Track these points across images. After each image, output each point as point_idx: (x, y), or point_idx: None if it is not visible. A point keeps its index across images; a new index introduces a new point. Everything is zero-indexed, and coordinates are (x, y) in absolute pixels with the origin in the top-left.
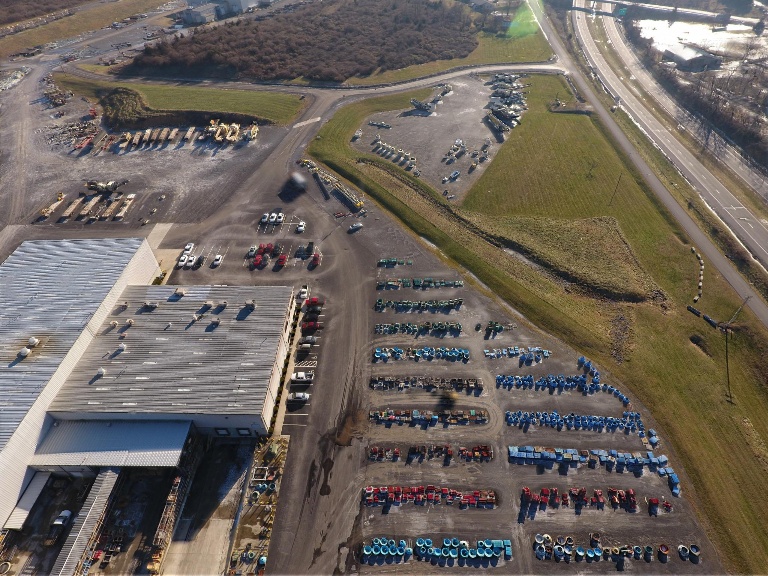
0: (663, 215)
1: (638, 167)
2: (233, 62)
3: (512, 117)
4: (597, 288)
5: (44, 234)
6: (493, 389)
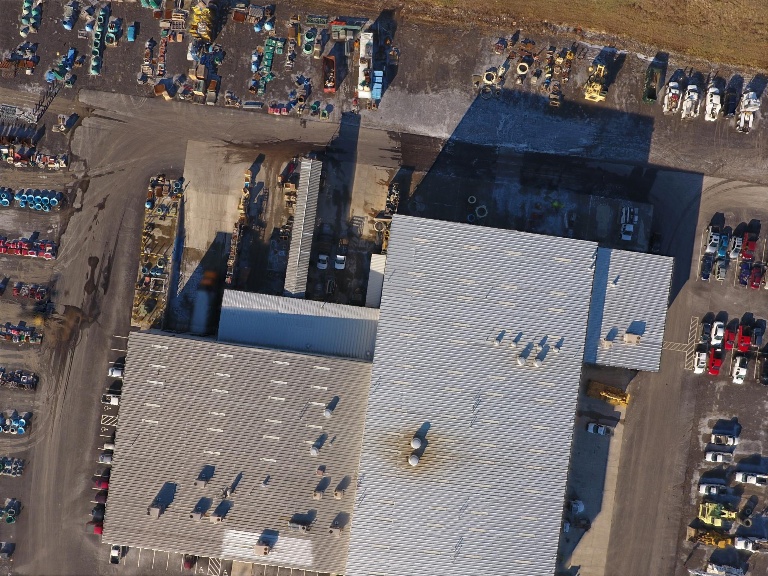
0: None
1: None
2: None
3: None
4: None
5: None
6: None
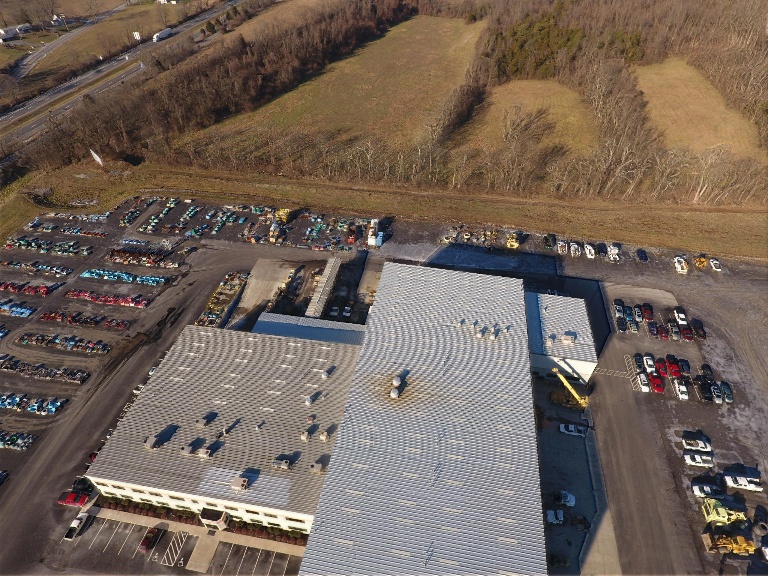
0: None
1: None
2: None
3: None
4: None
5: None
6: None
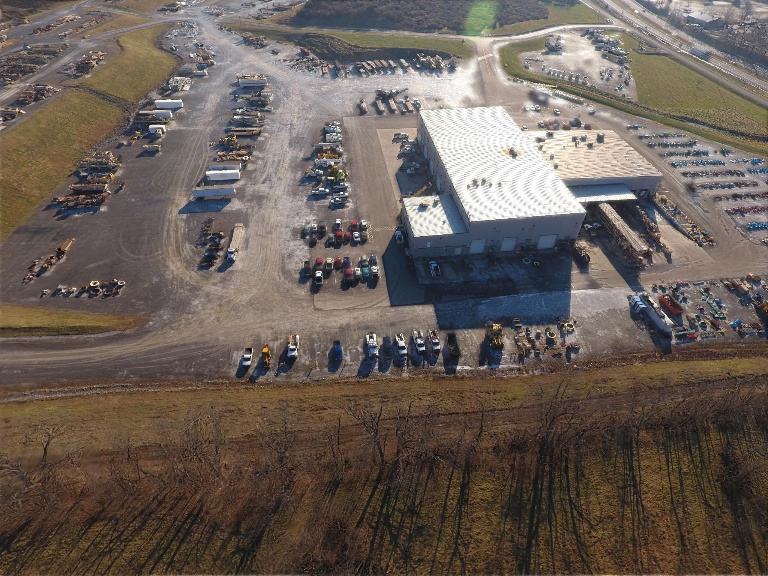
0: (761, 106)
1: (726, 83)
2: (391, 15)
3: (623, 55)
4: (758, 137)
5: (380, 120)
6: (749, 174)
